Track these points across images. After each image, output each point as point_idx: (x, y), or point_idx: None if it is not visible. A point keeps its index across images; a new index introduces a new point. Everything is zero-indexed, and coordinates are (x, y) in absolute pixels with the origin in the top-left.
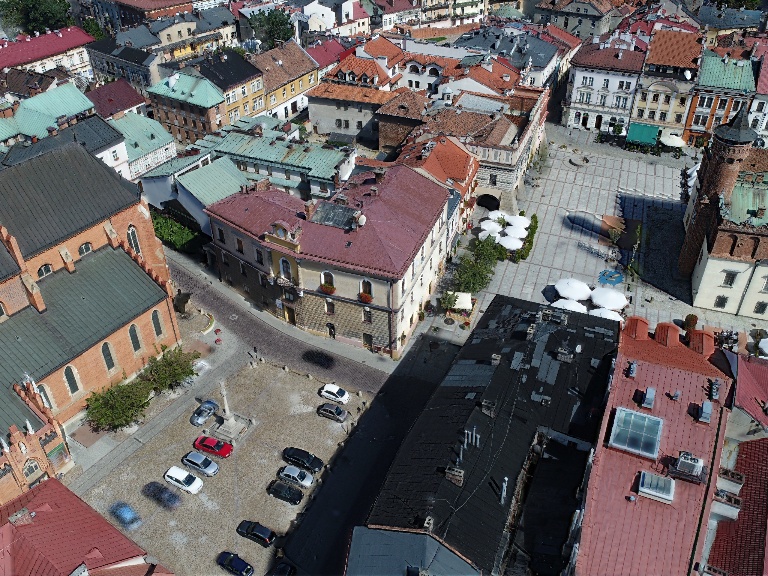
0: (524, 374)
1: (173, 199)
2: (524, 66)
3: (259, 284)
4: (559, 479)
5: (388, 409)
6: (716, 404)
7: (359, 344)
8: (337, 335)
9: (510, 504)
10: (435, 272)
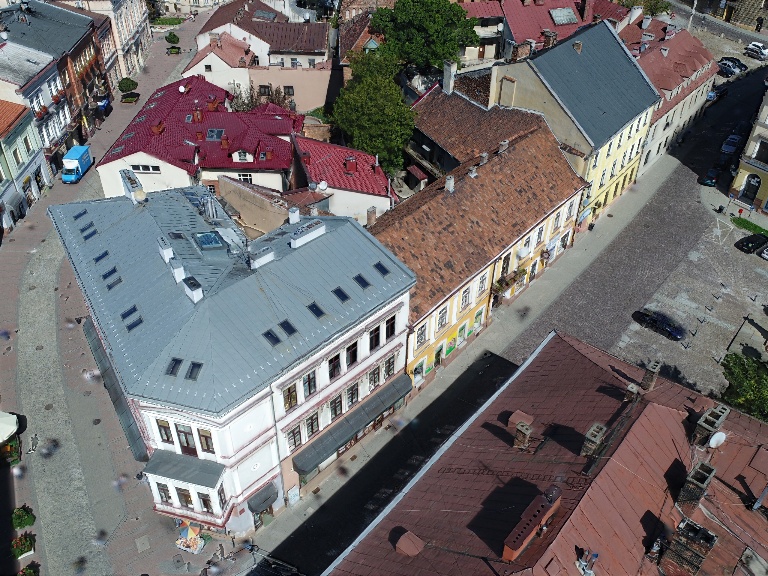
0: None
1: None
2: None
3: None
4: None
5: None
6: None
7: None
8: (762, 29)
9: None
10: None
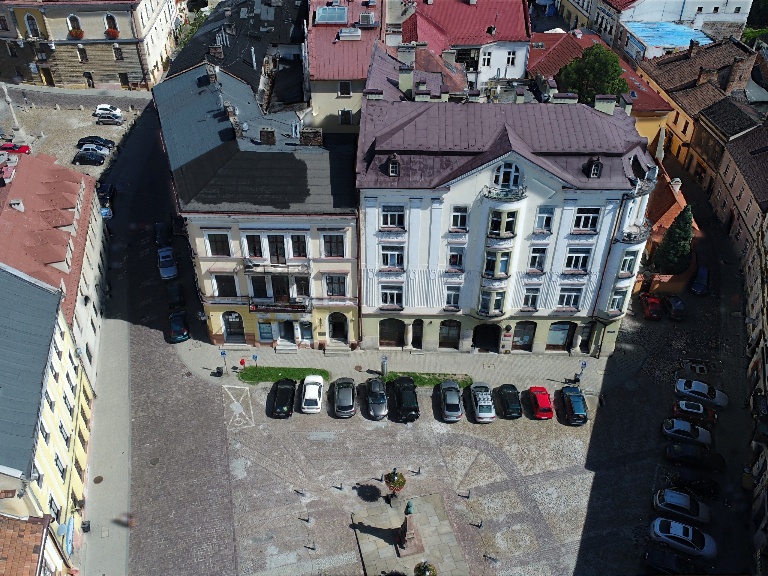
0: (251, 19)
1: None
2: None
3: (9, 56)
4: (293, 73)
5: None
6: None
7: (117, 86)
8: (95, 83)
9: (261, 70)
10: (167, 38)
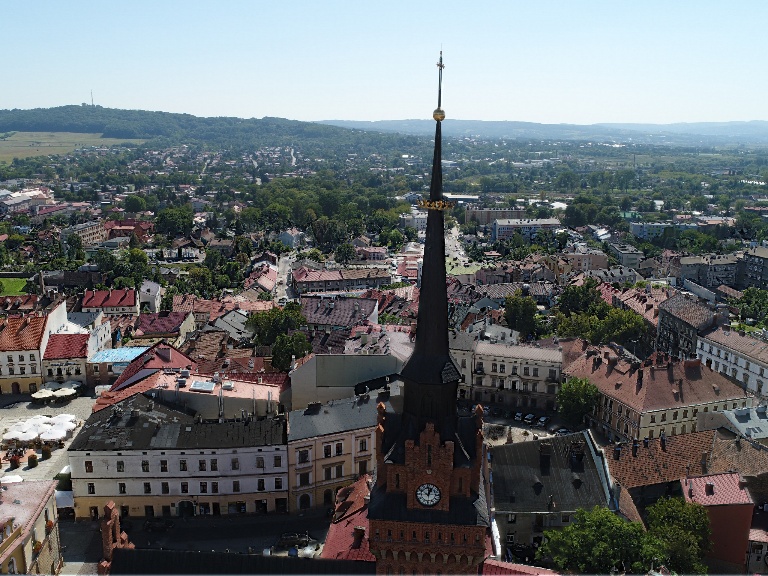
0: (163, 421)
1: None
2: None
3: None
4: None
5: None
6: (177, 374)
7: None
8: None
9: None
10: None
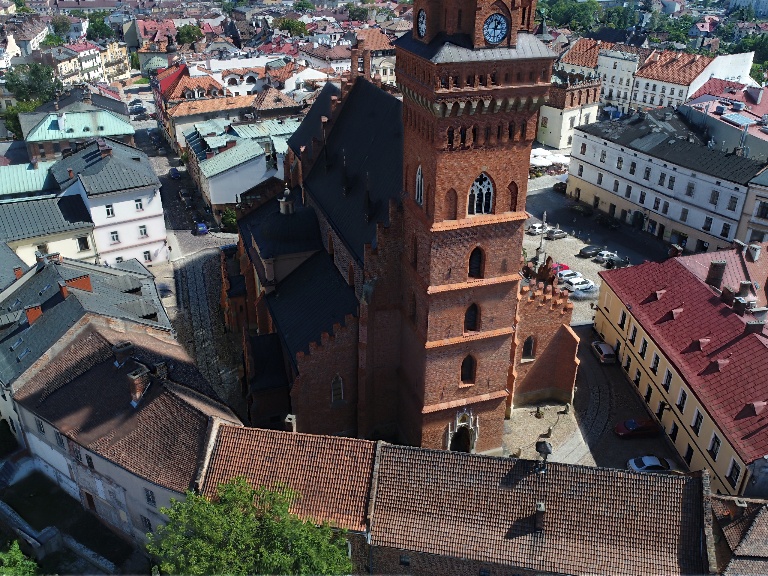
0: (664, 132)
1: (267, 179)
2: (308, 63)
3: None
4: None
5: (566, 225)
6: (732, 106)
7: None
8: None
9: None
10: None
